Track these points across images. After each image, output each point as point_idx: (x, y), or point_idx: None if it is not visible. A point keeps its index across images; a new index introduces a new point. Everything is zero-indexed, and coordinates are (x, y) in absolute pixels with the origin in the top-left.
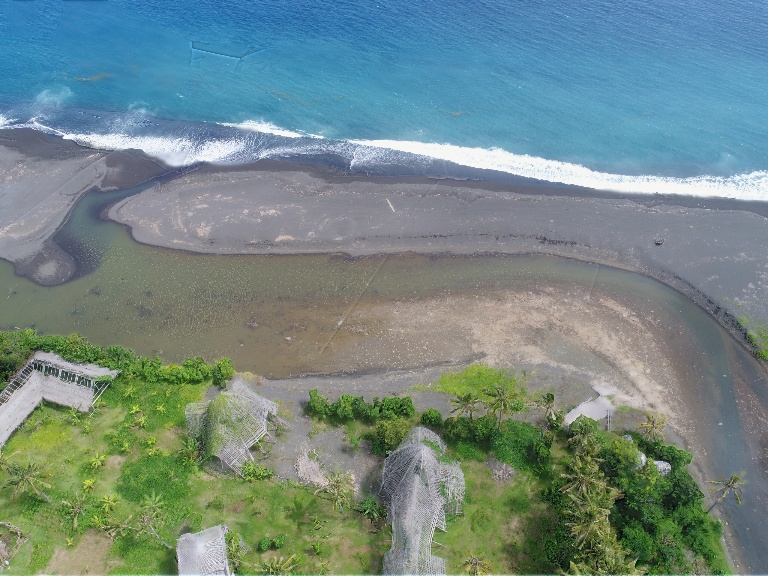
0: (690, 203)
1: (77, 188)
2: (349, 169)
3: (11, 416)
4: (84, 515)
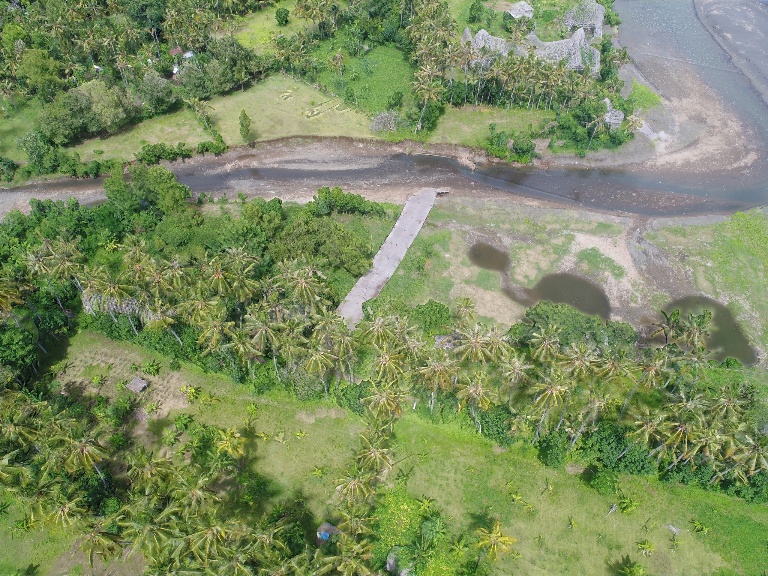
0: None
1: None
2: None
3: None
4: None
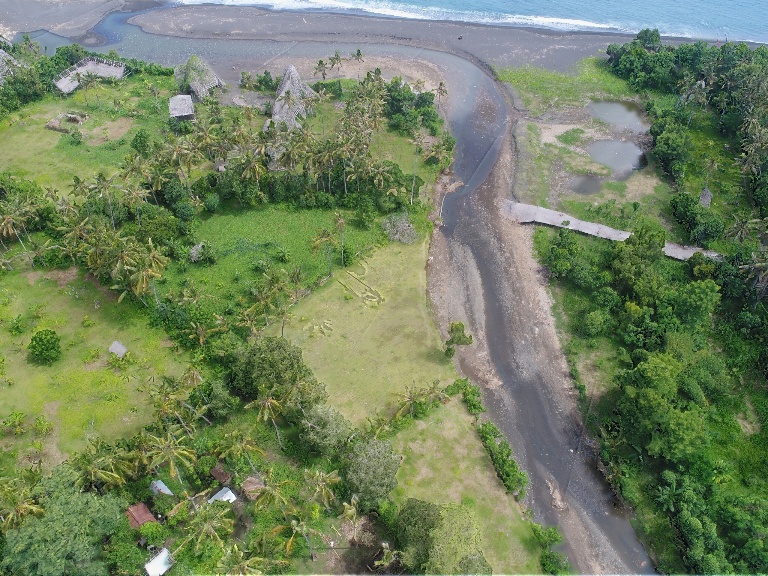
0: (489, 26)
1: (106, 9)
2: (282, 8)
3: None
4: (120, 112)
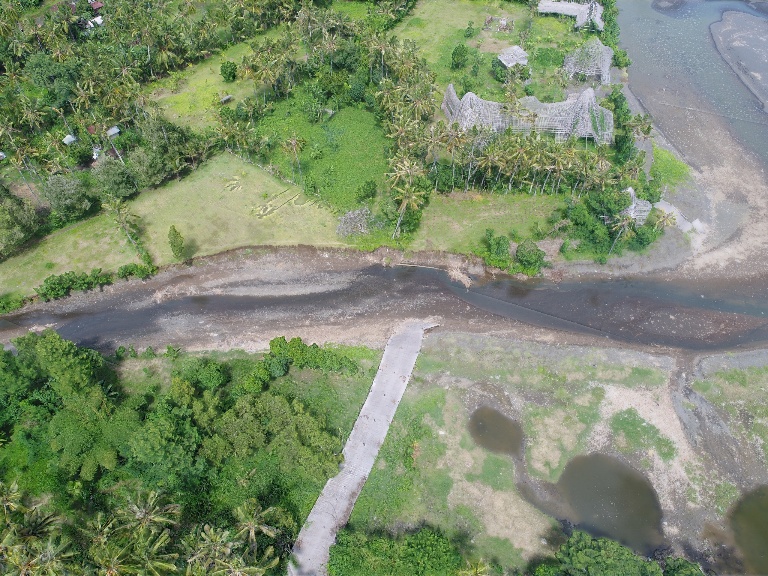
0: None
1: None
2: None
3: (563, 8)
4: None
